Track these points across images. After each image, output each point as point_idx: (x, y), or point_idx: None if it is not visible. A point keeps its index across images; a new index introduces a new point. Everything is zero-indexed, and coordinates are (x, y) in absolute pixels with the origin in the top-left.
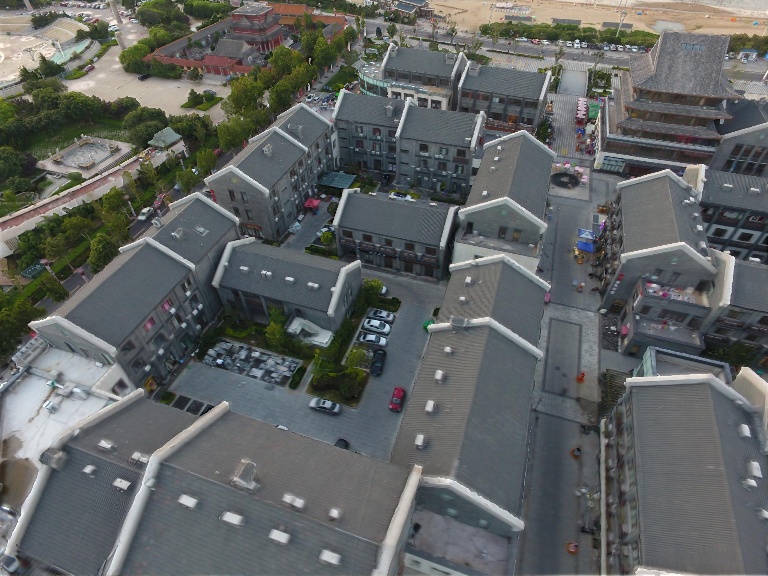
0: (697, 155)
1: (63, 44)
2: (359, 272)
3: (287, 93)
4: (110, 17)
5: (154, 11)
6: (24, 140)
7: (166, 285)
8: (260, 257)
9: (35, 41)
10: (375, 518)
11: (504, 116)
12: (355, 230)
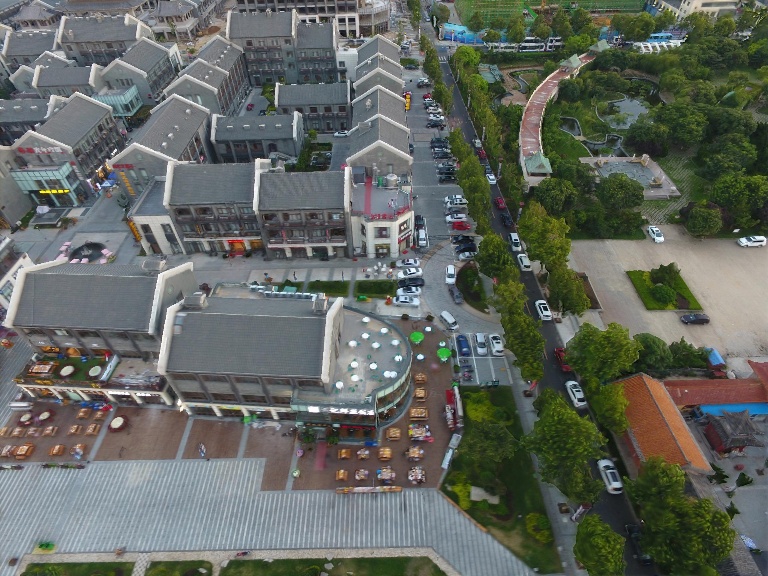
0: None
1: None
2: None
3: None
4: None
5: None
6: None
7: None
8: None
9: None
10: (235, 19)
11: None
12: None
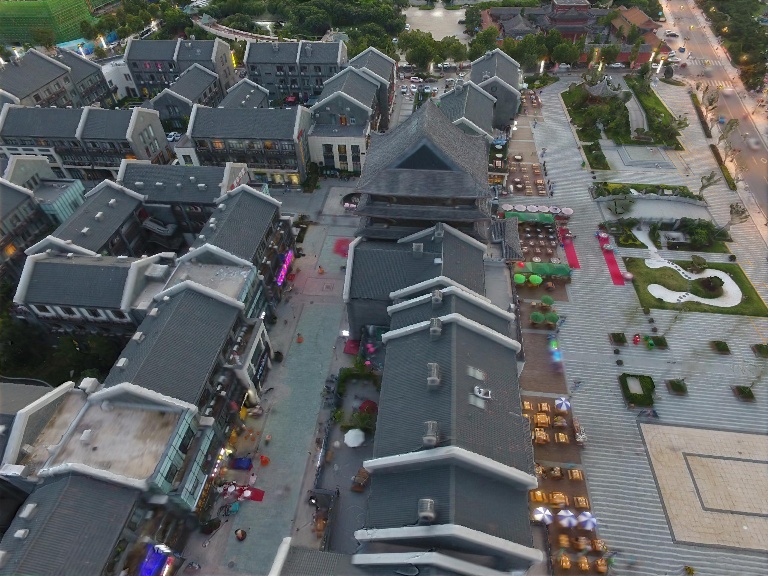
0: None
1: None
2: (189, 107)
3: (422, 53)
4: None
5: None
6: (349, 21)
7: (162, 57)
8: None
9: None
10: None
11: None
12: None
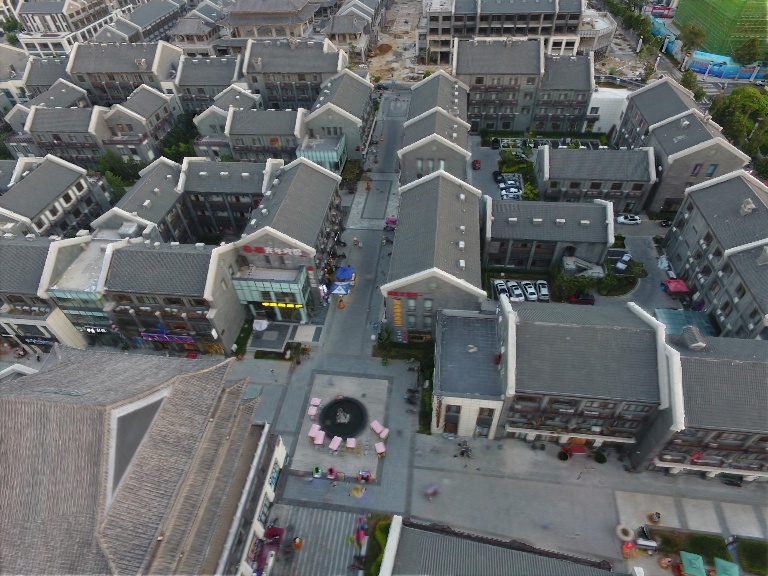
0: None
1: None
2: None
3: None
4: None
5: None
6: None
7: None
8: None
9: None
10: (463, 49)
11: None
12: None
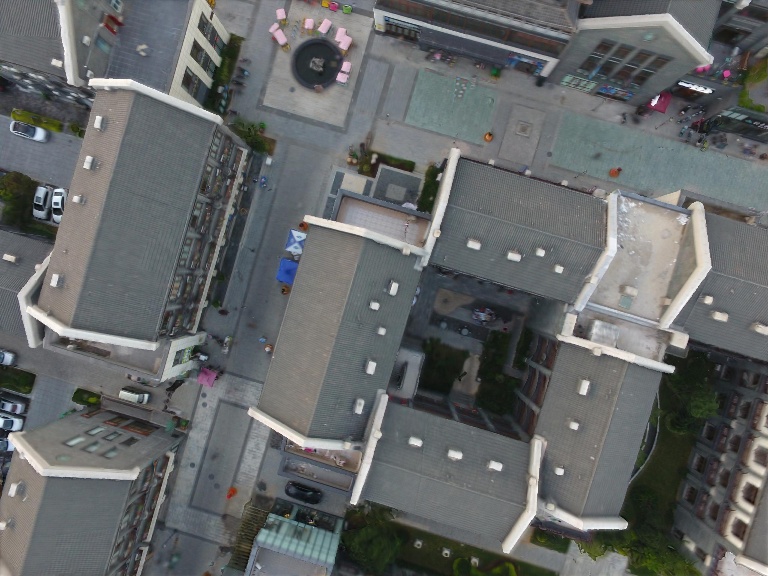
0: (539, 40)
1: None
2: None
3: None
4: None
5: None
6: None
7: None
8: None
9: None
10: None
11: None
12: None
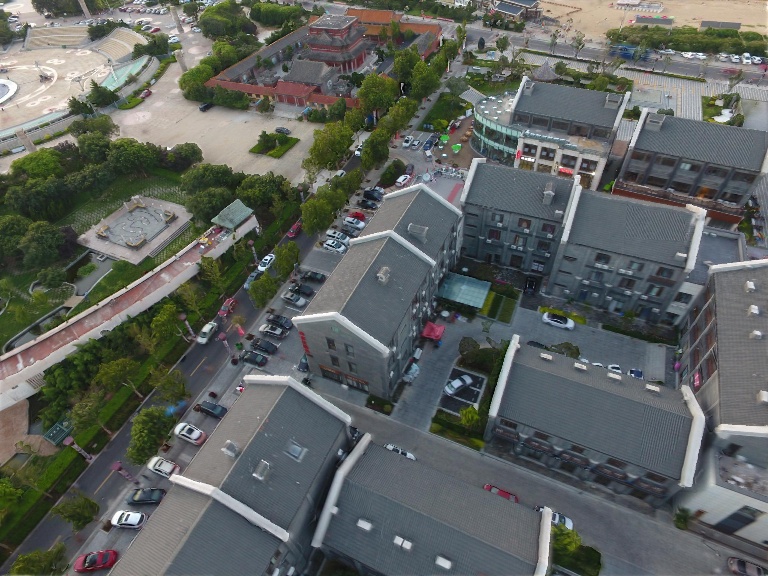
0: None
1: (119, 60)
2: None
3: (385, 144)
4: (170, 25)
5: (218, 19)
6: (66, 202)
7: None
8: (389, 504)
9: (91, 56)
10: None
11: (694, 188)
12: (524, 425)
